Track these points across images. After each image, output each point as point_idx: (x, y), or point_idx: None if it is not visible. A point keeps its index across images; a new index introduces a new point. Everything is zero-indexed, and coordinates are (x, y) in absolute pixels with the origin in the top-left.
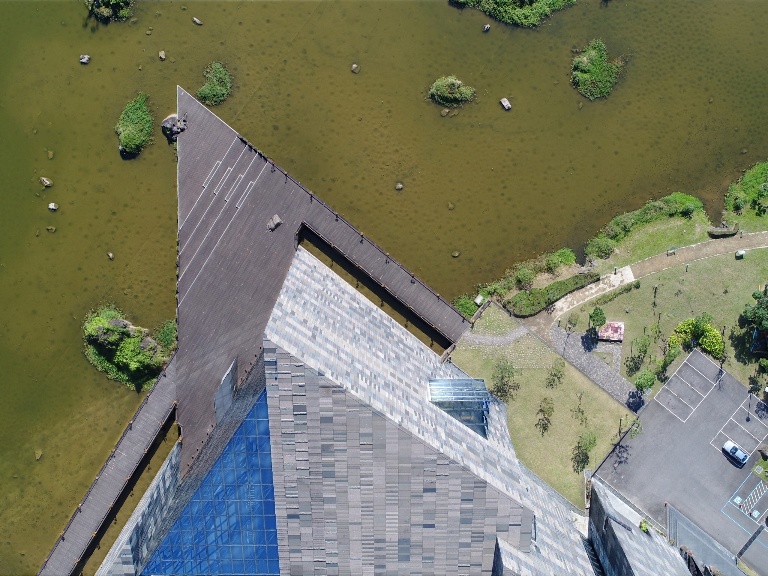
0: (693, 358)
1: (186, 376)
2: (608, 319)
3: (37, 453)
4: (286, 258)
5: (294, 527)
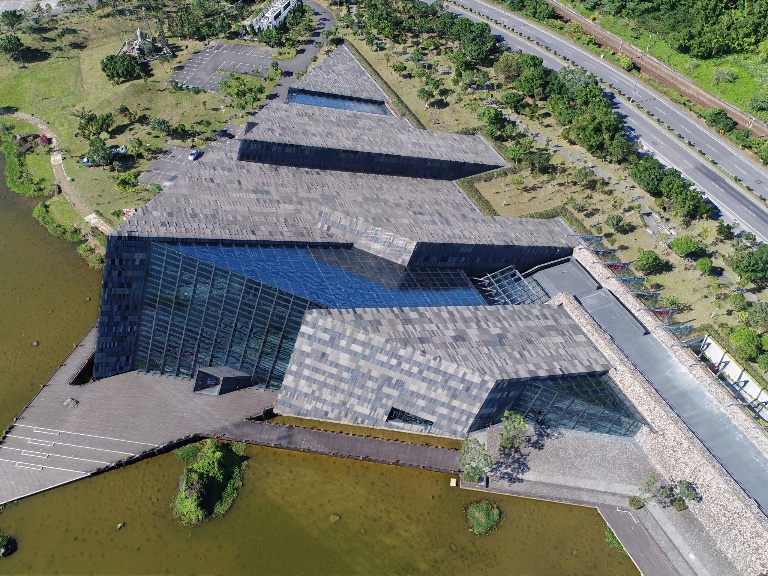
0: (141, 182)
1: (220, 420)
2: (122, 217)
3: (334, 520)
4: (102, 386)
5: (263, 233)
